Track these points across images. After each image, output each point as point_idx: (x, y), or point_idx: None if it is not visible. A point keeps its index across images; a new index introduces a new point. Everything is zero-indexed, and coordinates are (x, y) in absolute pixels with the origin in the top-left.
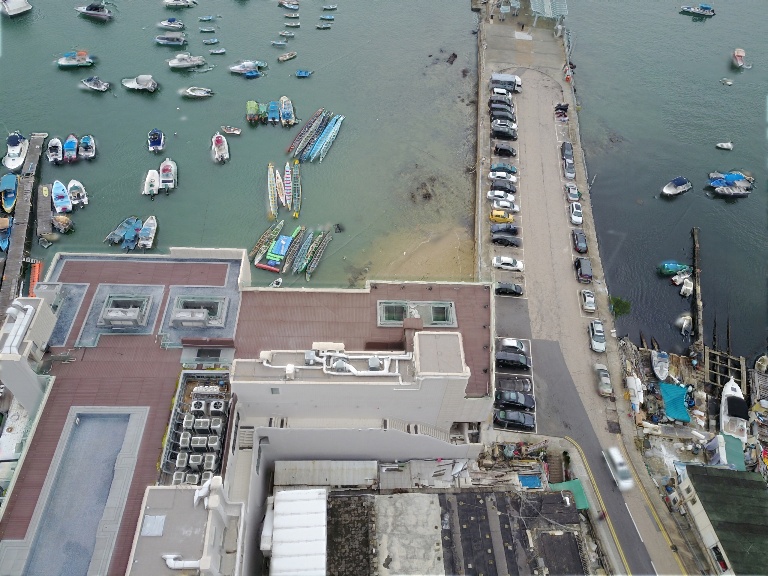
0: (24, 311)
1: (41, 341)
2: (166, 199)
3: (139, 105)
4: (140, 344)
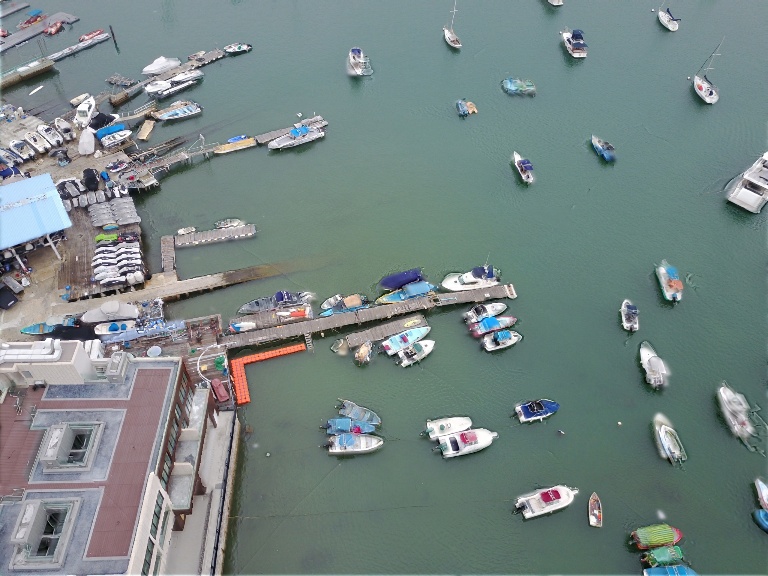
0: (52, 352)
1: (44, 378)
2: (427, 450)
3: (621, 374)
4: (17, 473)
